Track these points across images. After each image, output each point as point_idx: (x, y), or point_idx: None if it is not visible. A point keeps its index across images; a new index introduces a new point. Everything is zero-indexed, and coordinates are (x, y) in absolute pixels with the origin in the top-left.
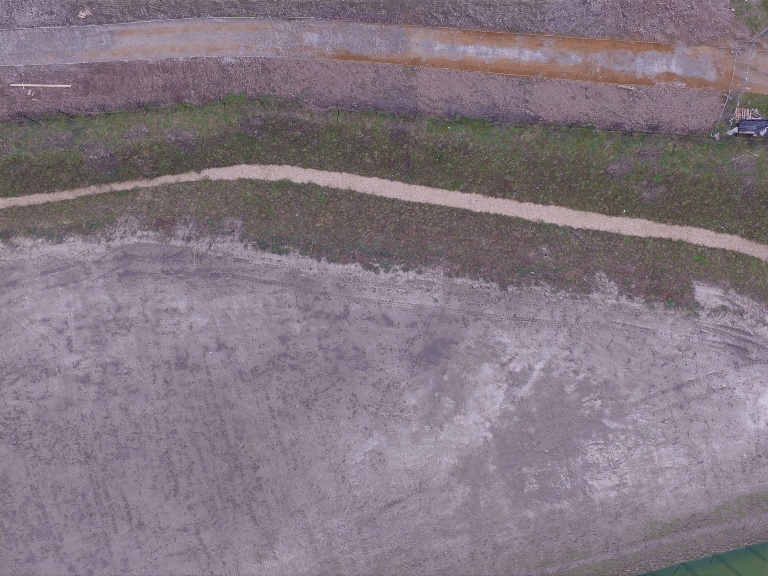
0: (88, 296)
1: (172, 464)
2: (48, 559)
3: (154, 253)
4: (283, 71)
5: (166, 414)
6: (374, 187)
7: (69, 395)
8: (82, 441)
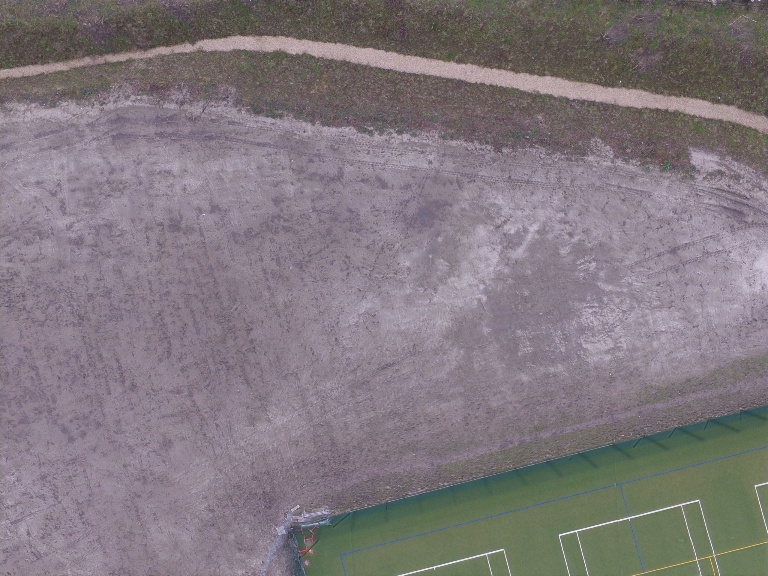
0: (81, 159)
1: (165, 326)
2: (41, 420)
3: (148, 116)
4: None
5: (159, 276)
6: (369, 58)
7: (62, 257)
8: (75, 303)
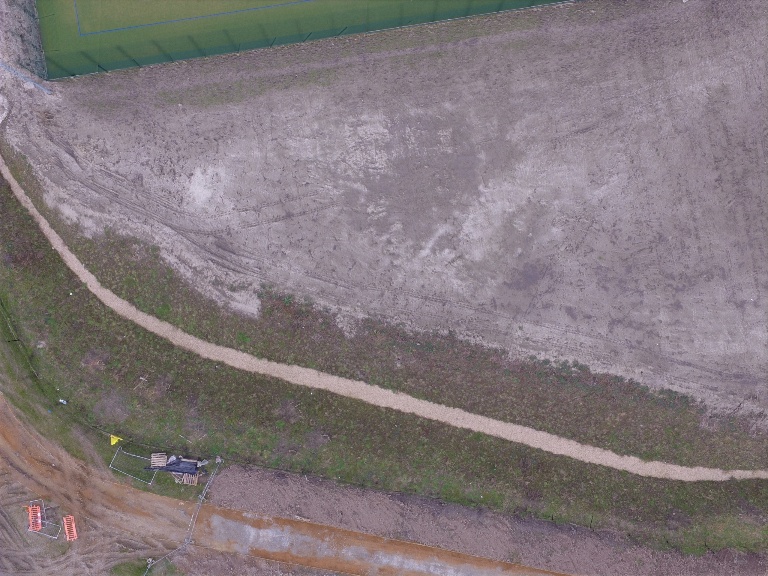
0: None
1: None
2: None
3: None
4: (642, 572)
5: None
6: (558, 444)
7: None
8: None
